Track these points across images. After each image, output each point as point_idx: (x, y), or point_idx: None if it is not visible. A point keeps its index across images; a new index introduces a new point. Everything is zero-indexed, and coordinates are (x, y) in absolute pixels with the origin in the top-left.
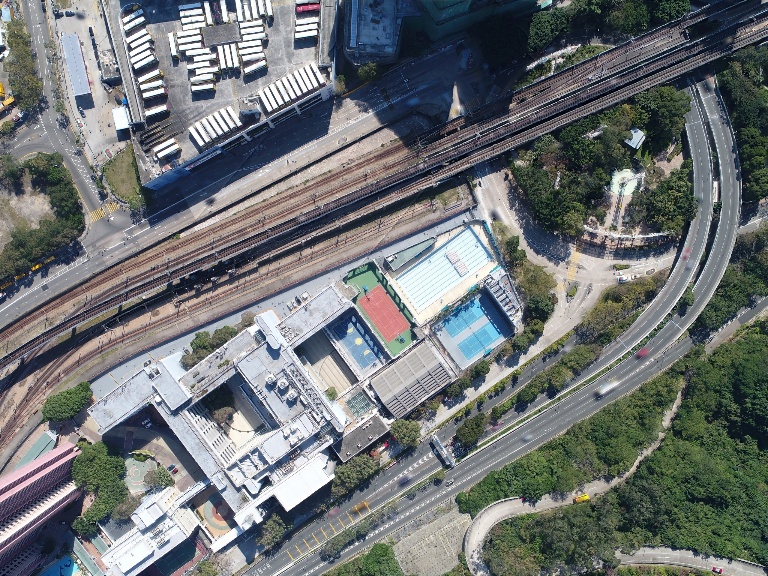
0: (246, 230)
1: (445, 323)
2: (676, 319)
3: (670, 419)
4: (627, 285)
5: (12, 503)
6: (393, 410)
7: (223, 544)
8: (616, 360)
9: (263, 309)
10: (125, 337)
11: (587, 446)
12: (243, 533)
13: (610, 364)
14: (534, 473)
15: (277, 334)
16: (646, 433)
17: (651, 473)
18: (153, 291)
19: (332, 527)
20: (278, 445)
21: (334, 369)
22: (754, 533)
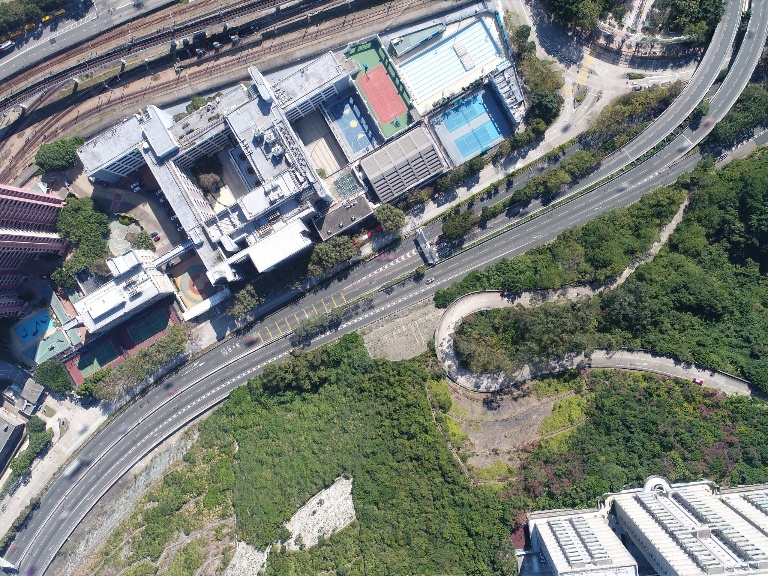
0: None
1: (444, 117)
2: (687, 133)
3: (668, 235)
4: (639, 92)
5: None
6: (379, 192)
7: (195, 313)
8: (618, 170)
9: None
10: (124, 98)
11: (575, 247)
12: (217, 309)
13: (611, 174)
14: (517, 271)
15: (270, 91)
16: (640, 241)
17: (640, 280)
18: (156, 54)
19: (306, 314)
20: (258, 201)
21: (326, 152)
22: (743, 350)
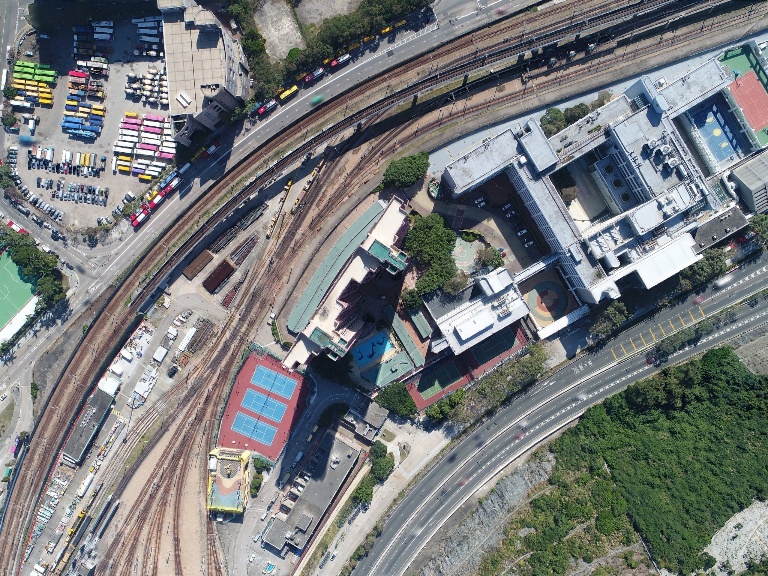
0: (610, 6)
1: None
2: None
3: None
4: None
5: (403, 228)
6: (757, 202)
7: (552, 331)
8: None
9: (614, 93)
10: (467, 111)
11: None
12: (567, 326)
13: None
14: None
15: None
16: None
17: None
18: (502, 65)
19: (662, 329)
20: (650, 215)
21: None
22: None
